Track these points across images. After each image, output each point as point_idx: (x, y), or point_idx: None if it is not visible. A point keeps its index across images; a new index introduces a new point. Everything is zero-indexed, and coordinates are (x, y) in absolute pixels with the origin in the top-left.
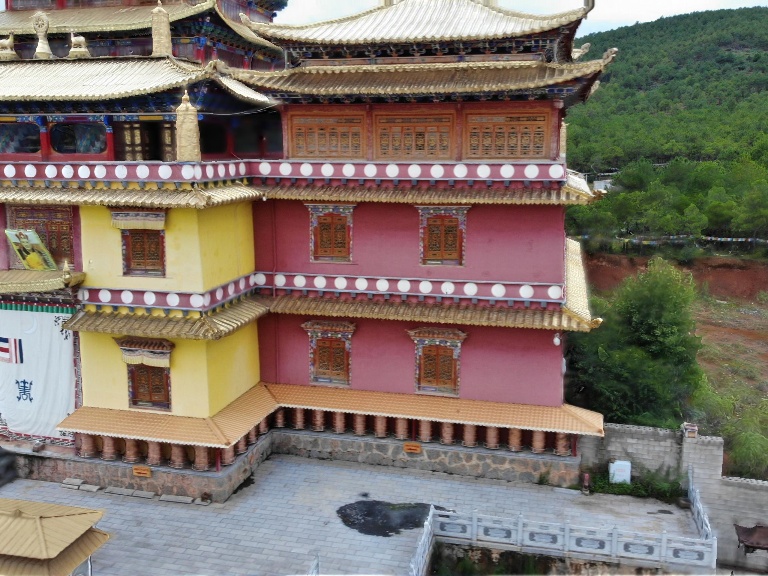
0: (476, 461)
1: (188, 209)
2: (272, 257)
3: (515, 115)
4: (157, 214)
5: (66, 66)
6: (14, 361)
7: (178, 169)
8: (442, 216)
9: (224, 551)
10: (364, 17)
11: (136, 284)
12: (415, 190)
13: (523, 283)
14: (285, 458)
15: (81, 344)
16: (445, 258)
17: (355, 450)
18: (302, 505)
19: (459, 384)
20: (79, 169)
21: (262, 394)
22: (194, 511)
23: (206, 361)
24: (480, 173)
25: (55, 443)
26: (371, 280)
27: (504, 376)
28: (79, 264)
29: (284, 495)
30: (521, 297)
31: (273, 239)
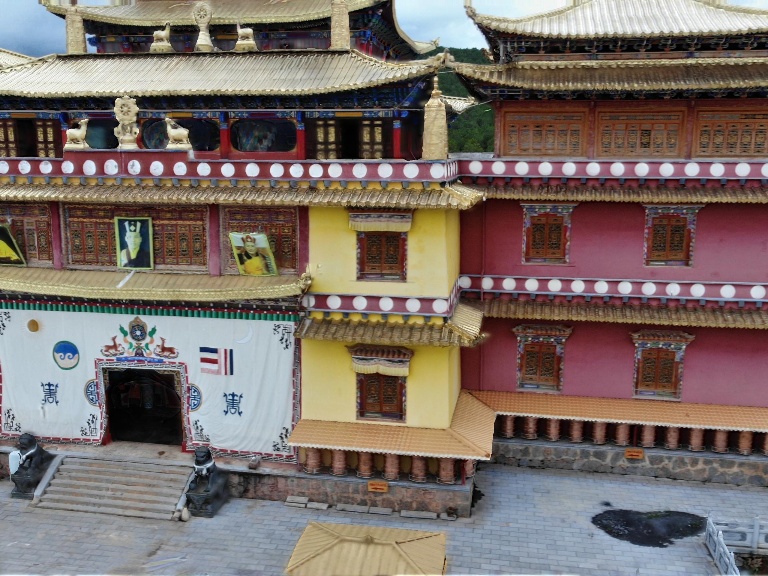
0: (702, 466)
1: (439, 210)
2: (480, 259)
3: (750, 112)
4: (403, 215)
5: (238, 59)
6: (223, 373)
7: (426, 168)
8: (669, 216)
9: (510, 569)
10: (570, 11)
11: (371, 289)
12: (645, 189)
13: (755, 283)
14: (495, 468)
15: (303, 353)
16: (670, 259)
17: (570, 457)
18: (552, 517)
19: (681, 387)
20: (310, 168)
21: (475, 402)
22: (446, 527)
23: (448, 369)
24: (713, 172)
25: (267, 459)
26: (589, 282)
27: (730, 378)
28: (305, 269)
29: (526, 507)
30: (752, 298)
31: (482, 241)
